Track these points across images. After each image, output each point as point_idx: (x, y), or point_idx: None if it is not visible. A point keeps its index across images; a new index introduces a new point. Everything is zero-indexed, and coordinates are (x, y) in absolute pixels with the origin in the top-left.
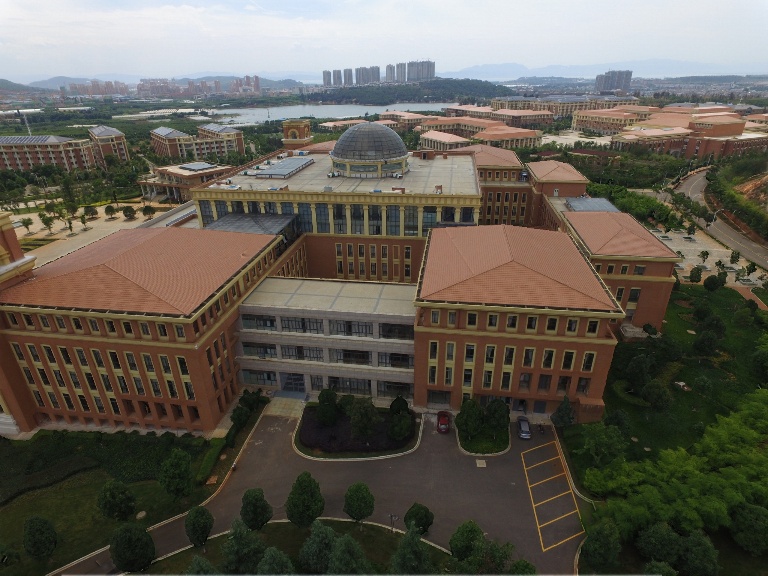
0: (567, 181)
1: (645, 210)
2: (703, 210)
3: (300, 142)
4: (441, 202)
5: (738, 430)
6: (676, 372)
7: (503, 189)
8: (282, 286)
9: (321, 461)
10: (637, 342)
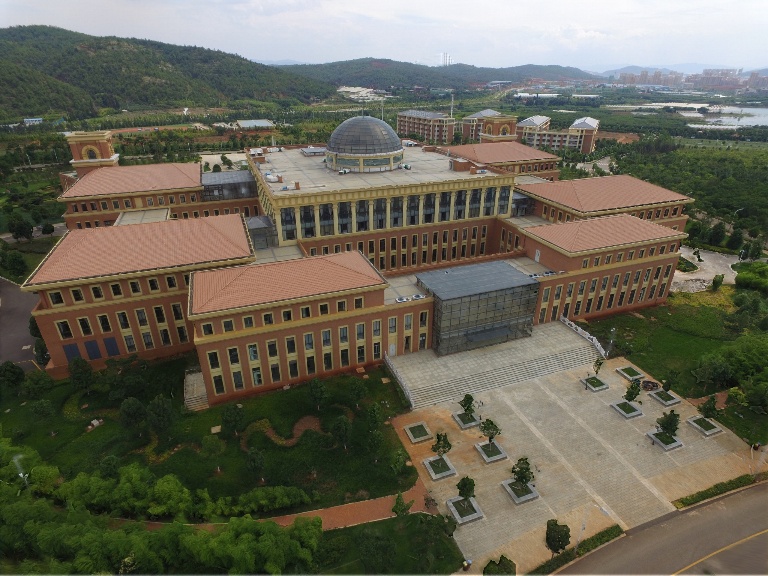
0: (546, 243)
1: (717, 363)
2: None
3: (491, 138)
4: None
5: None
6: None
7: None
8: (155, 214)
9: None
10: (118, 361)
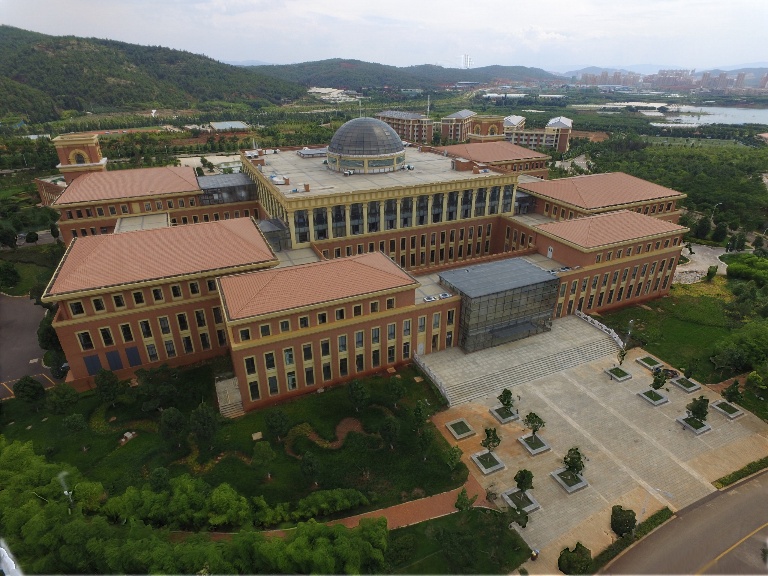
0: (560, 239)
1: None
2: None
3: (479, 138)
4: (279, 198)
5: (2, 454)
6: (156, 431)
7: (527, 230)
8: (154, 219)
9: (45, 312)
10: (147, 371)
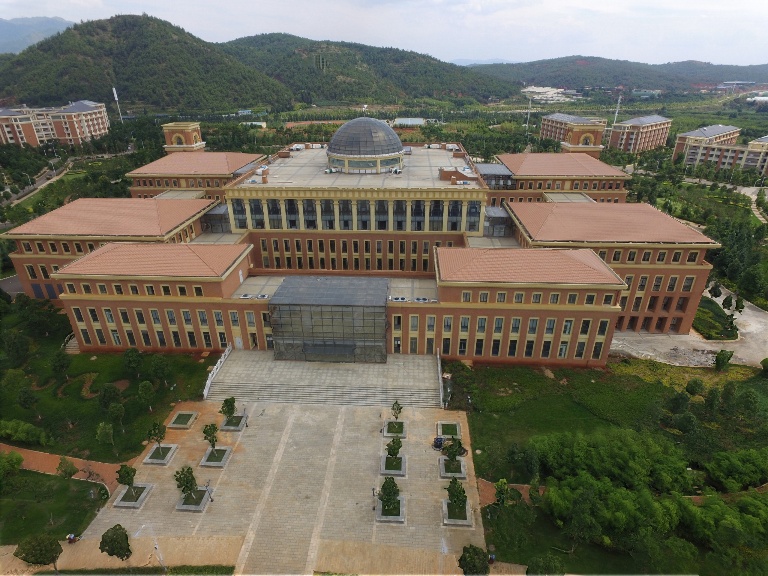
0: None
1: (538, 448)
2: (530, 559)
3: (568, 148)
4: None
5: None
6: None
7: None
8: (189, 194)
9: None
10: None
